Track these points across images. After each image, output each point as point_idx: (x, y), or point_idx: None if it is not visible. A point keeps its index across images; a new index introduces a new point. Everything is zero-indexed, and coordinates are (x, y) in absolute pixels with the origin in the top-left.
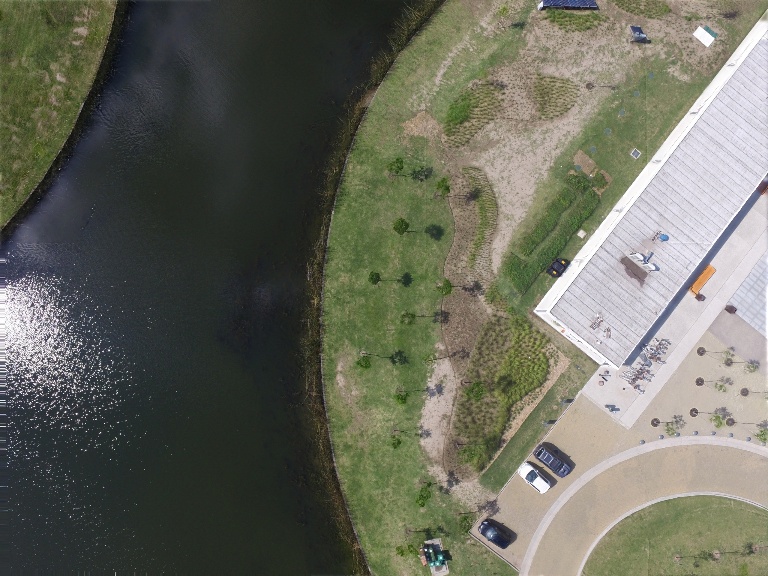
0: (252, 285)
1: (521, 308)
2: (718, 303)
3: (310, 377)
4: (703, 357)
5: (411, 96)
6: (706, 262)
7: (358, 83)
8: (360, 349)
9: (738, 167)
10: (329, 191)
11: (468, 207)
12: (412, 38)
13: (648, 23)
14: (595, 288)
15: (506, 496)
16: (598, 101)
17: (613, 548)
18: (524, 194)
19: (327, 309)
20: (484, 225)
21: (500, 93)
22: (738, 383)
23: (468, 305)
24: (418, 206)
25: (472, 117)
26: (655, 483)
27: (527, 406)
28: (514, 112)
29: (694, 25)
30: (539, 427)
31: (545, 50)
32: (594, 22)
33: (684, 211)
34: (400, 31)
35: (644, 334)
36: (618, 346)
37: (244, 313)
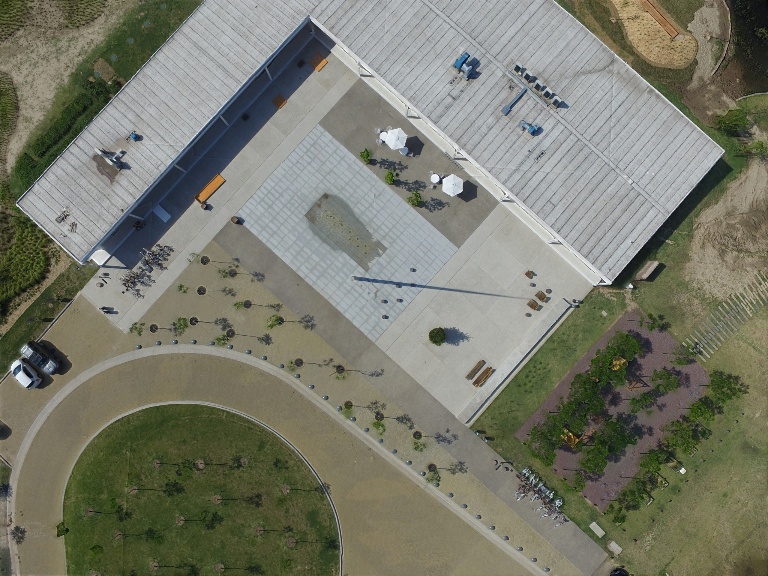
0: None
1: None
2: (225, 213)
3: None
4: (206, 266)
5: None
6: (216, 172)
7: None
8: None
9: (219, 72)
10: None
11: None
12: None
13: None
14: (65, 183)
15: (3, 391)
16: (124, 12)
17: (98, 449)
18: (44, 98)
19: None
20: (3, 126)
21: (28, 1)
22: (241, 295)
23: None
24: None
25: (2, 23)
26: (149, 389)
27: (24, 302)
28: (43, 20)
29: None
30: (33, 323)
31: None
32: None
33: (161, 113)
34: None
35: (108, 230)
36: (82, 241)
37: None
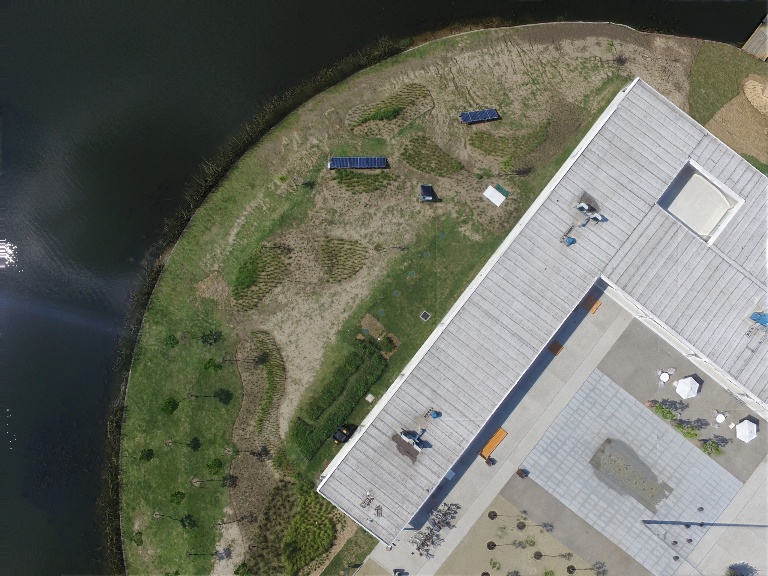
0: (55, 442)
1: (308, 473)
2: (510, 466)
3: (111, 533)
4: (494, 521)
5: (205, 256)
6: (497, 425)
7: (156, 240)
8: (154, 510)
9: (514, 341)
10: (128, 349)
11: (256, 371)
12: (208, 195)
13: (439, 181)
14: (366, 466)
15: None
16: (387, 263)
17: None
18: (312, 358)
19: (125, 468)
20: (271, 390)
21: (286, 257)
22: None
23: (256, 470)
24: (207, 370)
25: (259, 281)
26: None
27: (314, 571)
28: (302, 275)
29: (485, 184)
30: None
31: (332, 212)
32: (384, 182)
33: (458, 387)
34: (198, 187)
35: (415, 512)
36: (389, 524)
37: (47, 470)
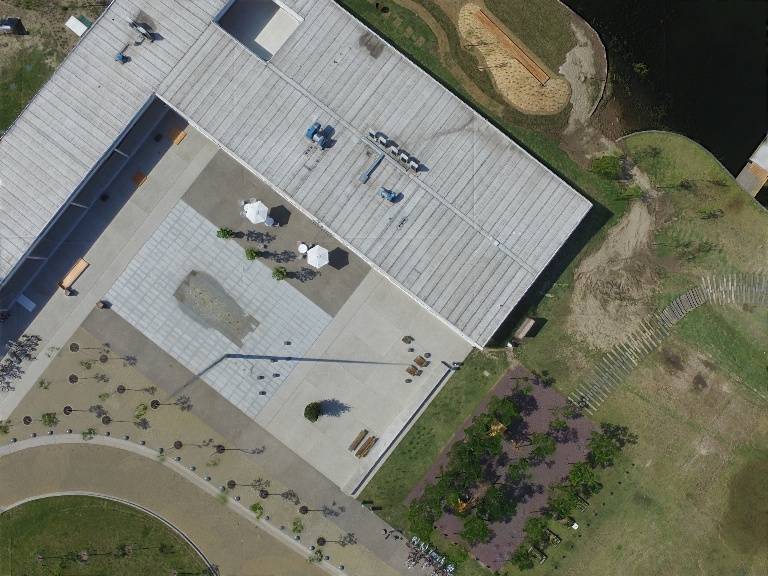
0: None
1: None
2: (92, 298)
3: None
4: (76, 353)
5: None
6: (79, 256)
7: None
8: None
9: (65, 158)
10: None
11: None
12: None
13: (27, 14)
14: None
15: None
16: None
17: None
18: None
19: None
20: None
21: None
22: (114, 380)
23: None
24: None
25: None
26: (27, 482)
27: None
28: None
29: (68, 15)
30: None
31: None
32: None
33: (8, 204)
34: None
35: None
36: None
37: None
